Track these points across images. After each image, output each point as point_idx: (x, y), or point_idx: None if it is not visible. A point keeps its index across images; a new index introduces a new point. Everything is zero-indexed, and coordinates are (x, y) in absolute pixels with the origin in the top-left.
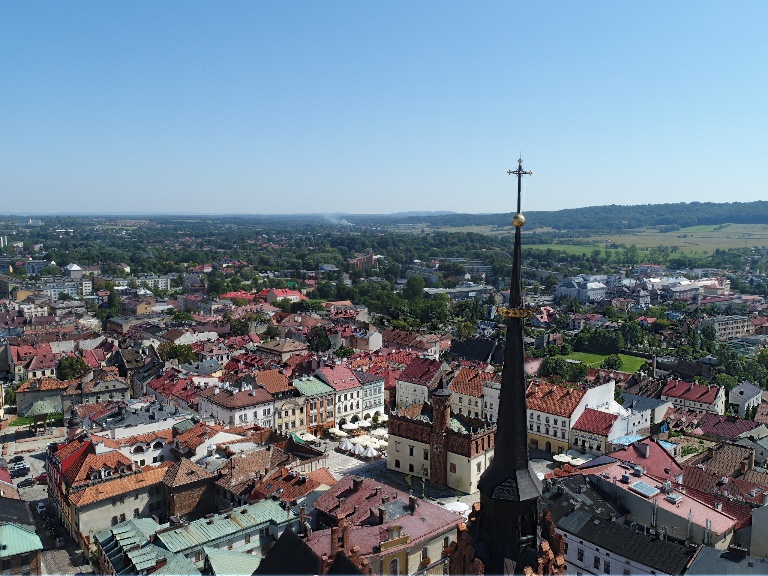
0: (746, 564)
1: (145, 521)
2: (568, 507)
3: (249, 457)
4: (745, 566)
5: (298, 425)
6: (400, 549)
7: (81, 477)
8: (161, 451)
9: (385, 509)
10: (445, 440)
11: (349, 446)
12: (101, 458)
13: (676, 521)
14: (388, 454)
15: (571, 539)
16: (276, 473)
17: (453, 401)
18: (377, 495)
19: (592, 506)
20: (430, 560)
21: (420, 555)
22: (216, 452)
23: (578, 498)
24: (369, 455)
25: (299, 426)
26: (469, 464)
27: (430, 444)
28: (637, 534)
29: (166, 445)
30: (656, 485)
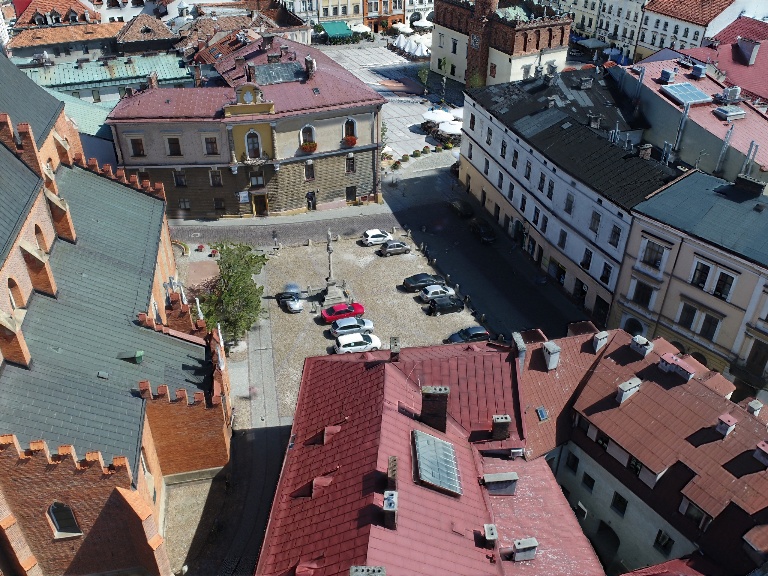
0: (751, 206)
1: (27, 61)
2: (543, 103)
3: (221, 21)
4: (747, 209)
5: (351, 12)
6: (255, 119)
7: (25, 19)
8: (143, 9)
9: (252, 65)
10: (486, 29)
11: (402, 42)
12: (51, 1)
13: (708, 143)
14: (431, 51)
15: (522, 146)
16: (227, 36)
17: (566, 2)
18: (281, 57)
19: (587, 109)
20: (317, 146)
21: (298, 136)
22: (193, 14)
23: (570, 95)
24: (417, 53)
25: (352, 14)
26: (509, 65)
27: (469, 35)
28: (610, 146)
29: (147, 2)
30: (716, 93)
